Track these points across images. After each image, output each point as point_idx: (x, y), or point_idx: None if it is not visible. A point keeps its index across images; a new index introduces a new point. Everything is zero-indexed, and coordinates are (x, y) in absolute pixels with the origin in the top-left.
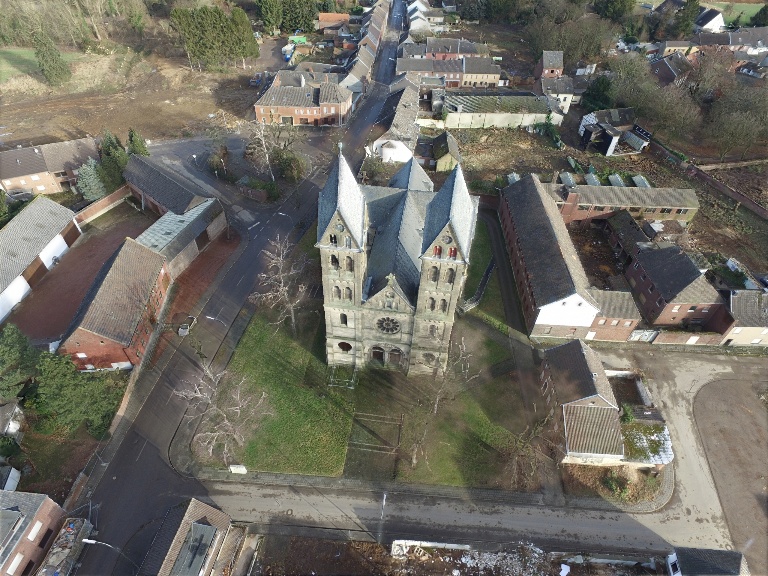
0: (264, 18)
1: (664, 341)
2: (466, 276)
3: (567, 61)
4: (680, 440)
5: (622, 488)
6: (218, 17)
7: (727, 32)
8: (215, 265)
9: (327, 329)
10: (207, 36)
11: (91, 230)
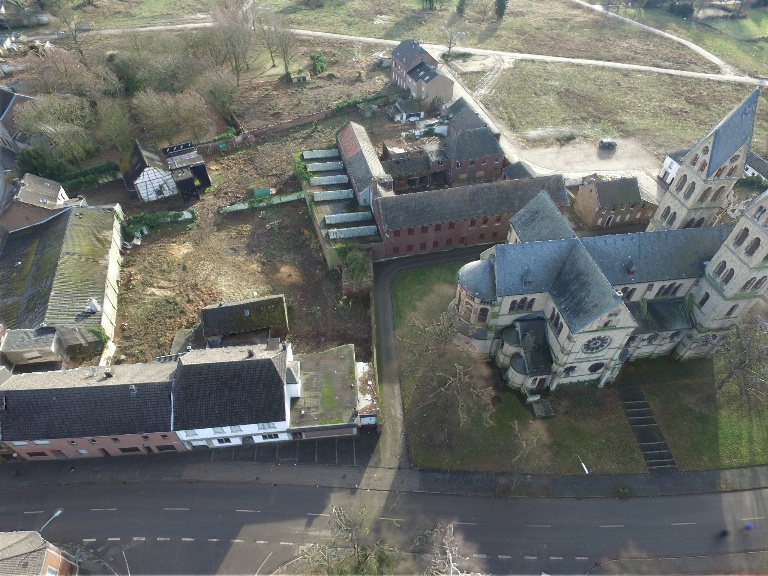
0: None
1: None
2: None
3: None
4: None
5: None
6: None
7: None
8: None
9: None
10: None
11: None
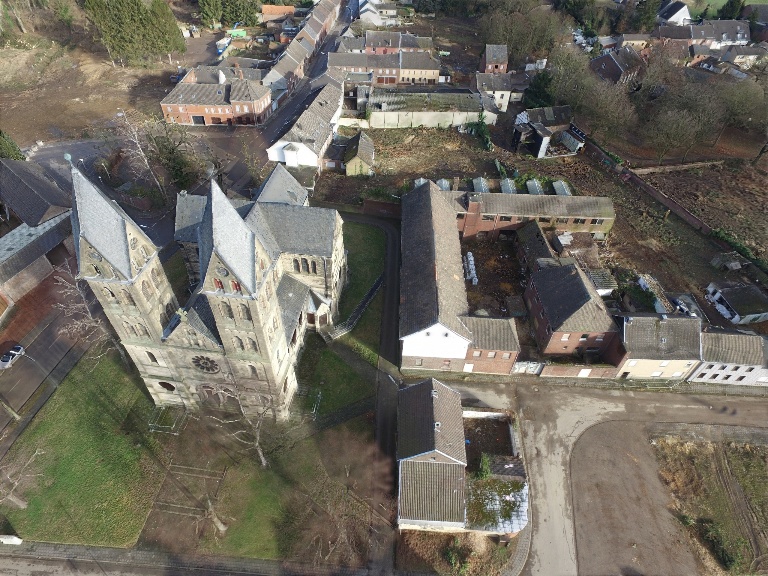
0: (202, 10)
1: (553, 374)
2: (335, 298)
3: (514, 56)
4: (547, 497)
5: (462, 562)
6: (136, 9)
7: (689, 25)
8: None
9: (138, 368)
10: (125, 29)
11: None
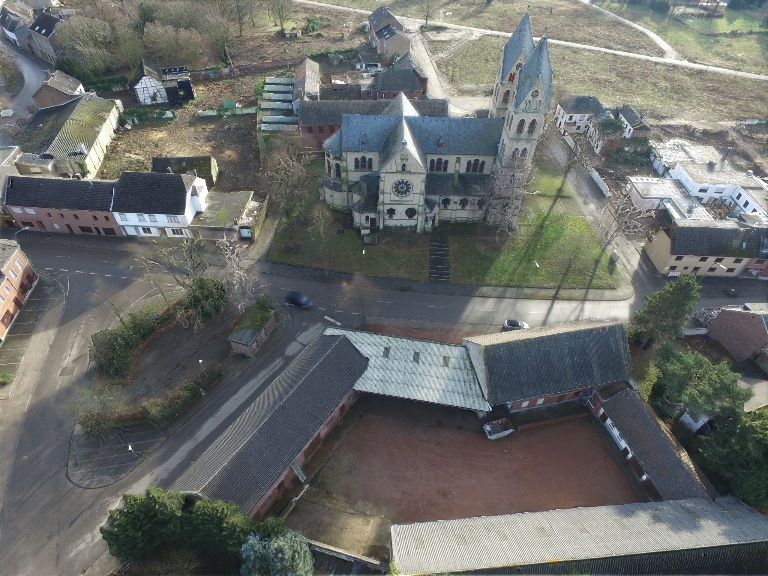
0: None
1: None
2: None
3: None
4: None
5: None
6: None
7: None
8: (419, 335)
9: None
10: None
11: (378, 540)
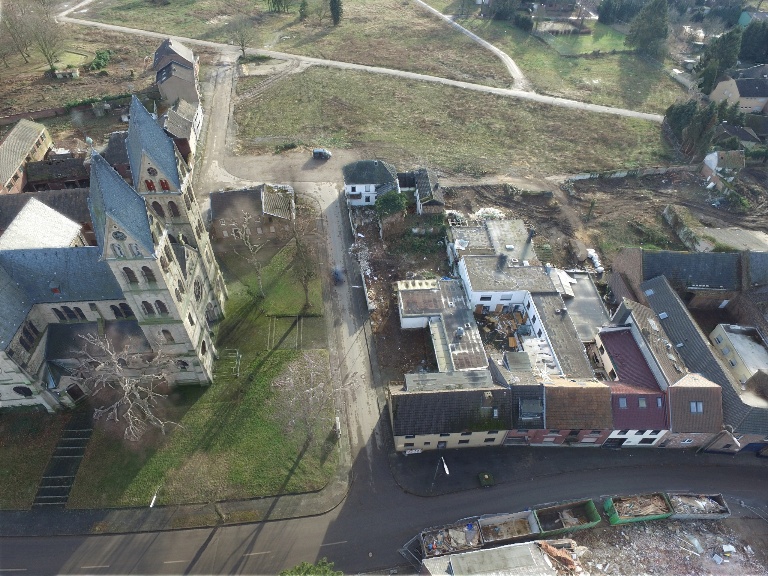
0: None
1: None
2: None
3: None
4: None
5: (308, 210)
6: None
7: None
8: None
9: (193, 346)
10: None
11: None
